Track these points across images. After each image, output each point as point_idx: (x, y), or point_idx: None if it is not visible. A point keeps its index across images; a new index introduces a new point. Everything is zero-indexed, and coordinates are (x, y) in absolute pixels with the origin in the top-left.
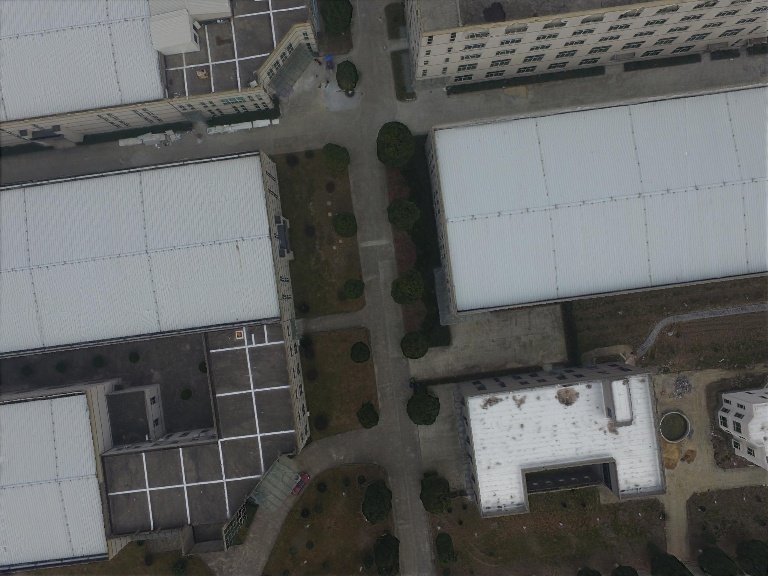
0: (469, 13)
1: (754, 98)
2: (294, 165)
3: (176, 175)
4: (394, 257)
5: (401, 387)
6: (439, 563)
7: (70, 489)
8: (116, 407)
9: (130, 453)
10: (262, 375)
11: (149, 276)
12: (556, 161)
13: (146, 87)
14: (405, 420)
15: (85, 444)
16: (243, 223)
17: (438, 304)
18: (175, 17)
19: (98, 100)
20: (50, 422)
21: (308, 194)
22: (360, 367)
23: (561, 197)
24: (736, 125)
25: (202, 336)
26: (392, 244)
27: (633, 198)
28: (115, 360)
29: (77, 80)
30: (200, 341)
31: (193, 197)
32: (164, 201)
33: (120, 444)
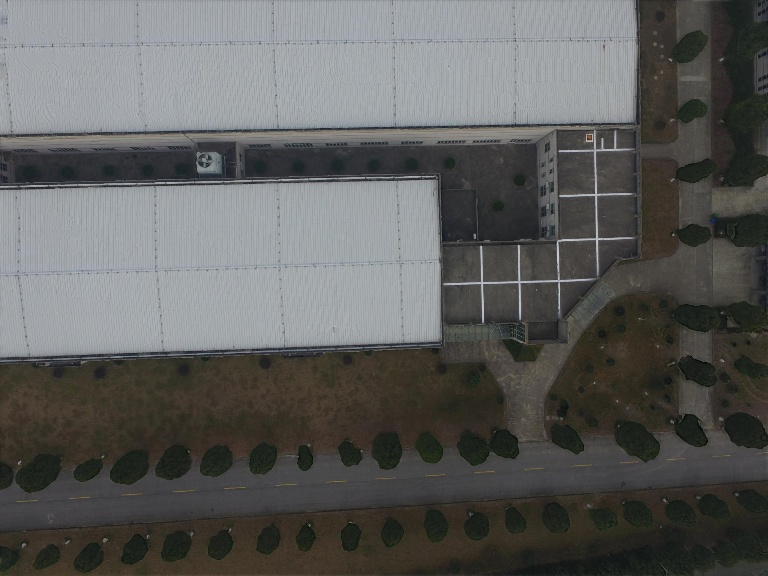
0: None
1: None
2: None
3: None
4: (710, 95)
5: (702, 222)
6: (716, 395)
7: (410, 272)
8: (444, 204)
9: (468, 245)
10: (607, 180)
11: (513, 65)
12: None
13: None
14: (702, 255)
15: (430, 229)
16: (612, 24)
17: (762, 138)
18: None
19: None
20: (395, 203)
21: None
22: (667, 198)
23: None
24: None
25: (556, 133)
26: (709, 82)
27: None
28: (427, 165)
29: None
30: (514, 156)
31: None
32: None
33: (446, 241)
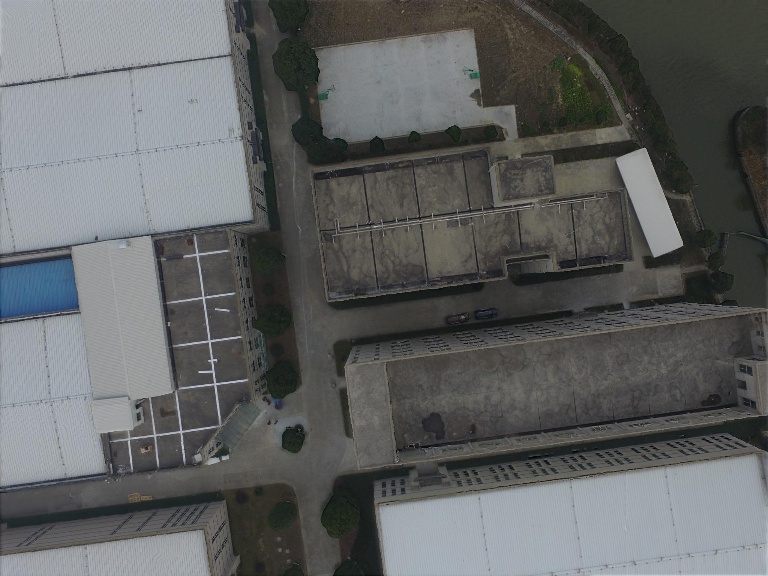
0: (408, 423)
1: (692, 471)
2: (244, 502)
3: (122, 549)
4: None
5: None
6: None
7: None
8: None
9: None
10: None
11: None
12: (498, 535)
13: (91, 455)
14: None
15: None
16: None
17: None
18: (117, 404)
19: (43, 467)
20: None
21: (258, 530)
22: None
23: (503, 572)
24: (674, 499)
25: None
26: None
27: (573, 573)
28: None
29: (21, 448)
30: None
31: (139, 571)
32: (110, 575)
33: None
